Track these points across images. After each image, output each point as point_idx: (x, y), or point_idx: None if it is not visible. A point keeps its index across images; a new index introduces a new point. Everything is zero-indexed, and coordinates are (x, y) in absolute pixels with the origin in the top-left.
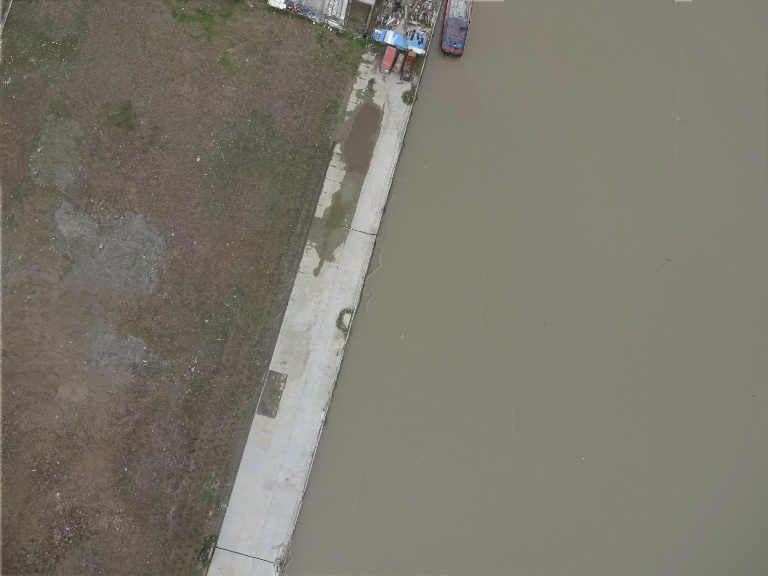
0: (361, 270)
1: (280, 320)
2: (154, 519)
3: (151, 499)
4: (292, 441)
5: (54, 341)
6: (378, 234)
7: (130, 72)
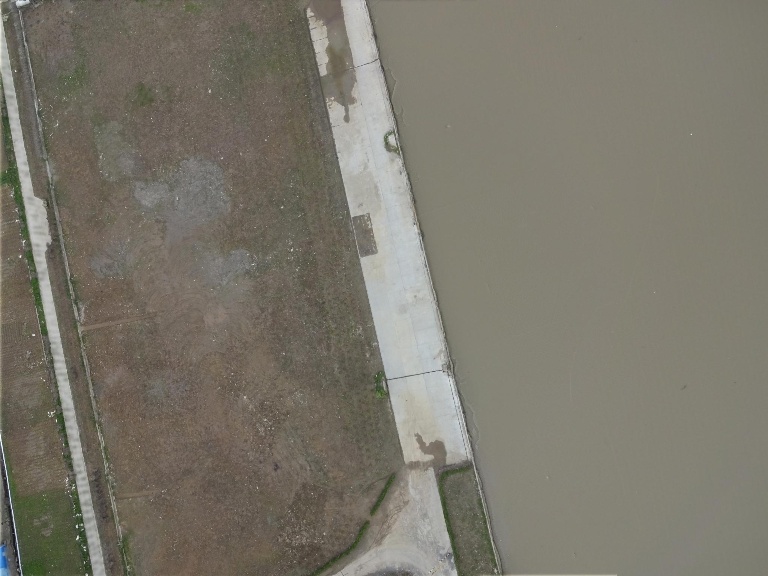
0: (382, 94)
1: (339, 174)
2: (326, 381)
3: (315, 367)
4: (402, 263)
5: (182, 286)
6: (381, 59)
7: (130, 61)
